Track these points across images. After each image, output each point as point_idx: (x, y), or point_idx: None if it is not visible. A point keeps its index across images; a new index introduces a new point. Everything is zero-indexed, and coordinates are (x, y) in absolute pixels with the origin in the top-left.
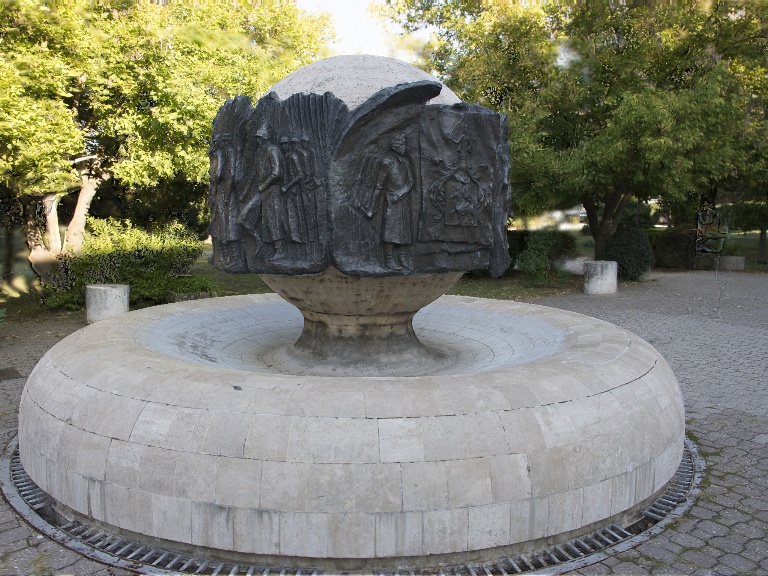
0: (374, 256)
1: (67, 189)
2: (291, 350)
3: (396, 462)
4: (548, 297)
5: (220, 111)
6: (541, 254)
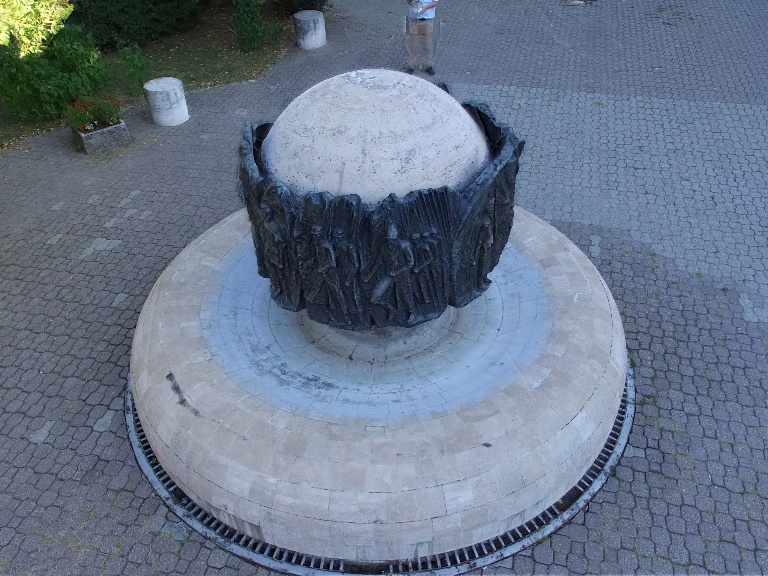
0: (473, 286)
1: None
2: (344, 332)
3: (588, 439)
4: (278, 65)
5: (307, 200)
6: (254, 17)
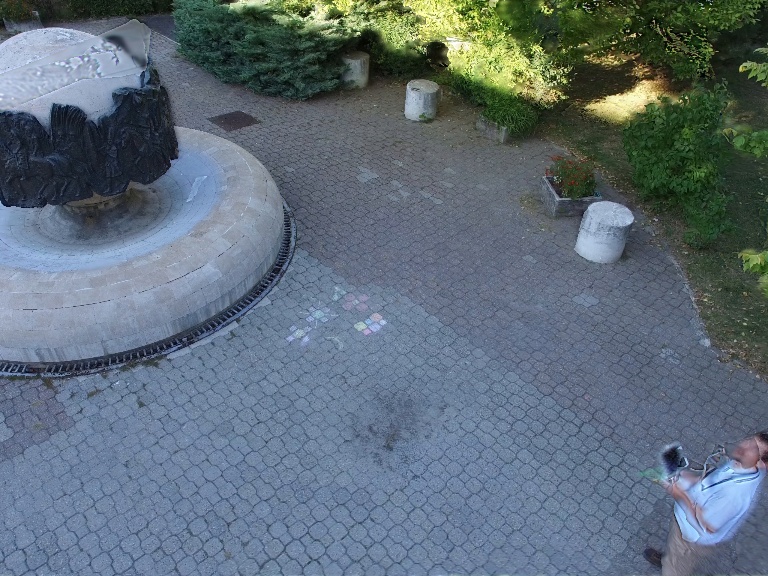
0: None
1: None
2: None
3: None
4: None
5: None
6: None
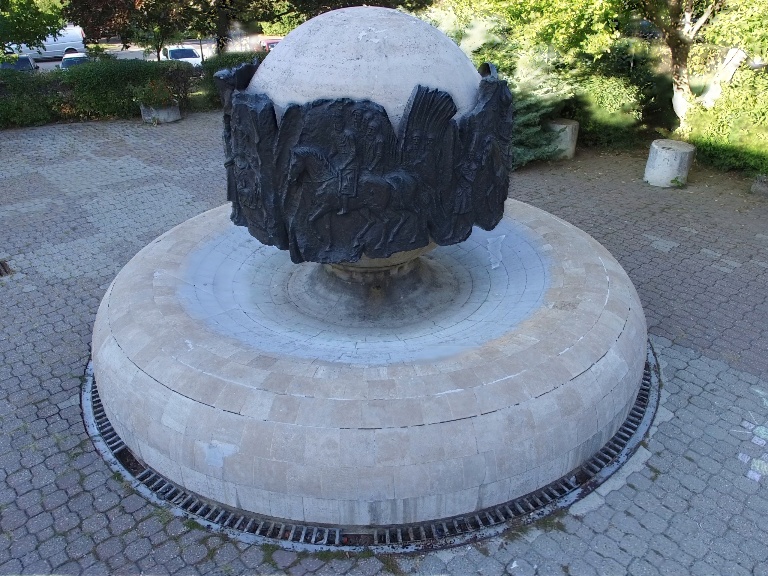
0: None
1: (600, 51)
2: None
3: None
4: None
5: None
6: None
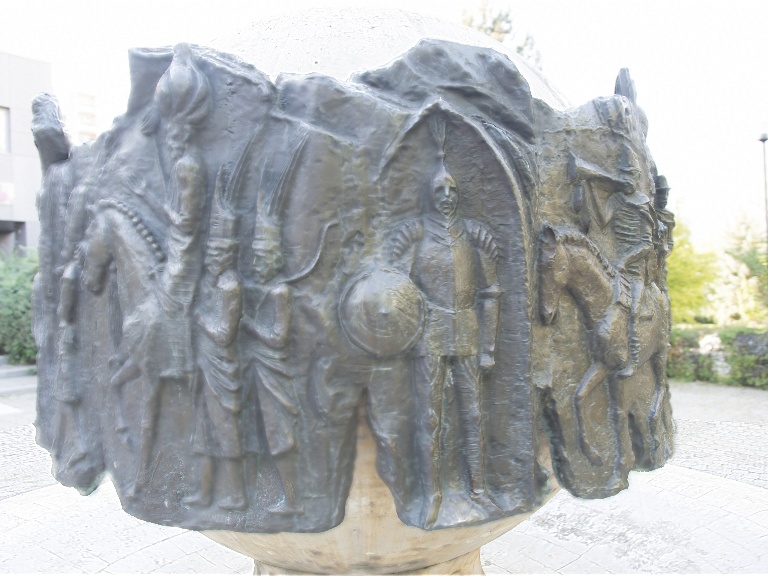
0: None
1: None
2: None
3: None
4: None
5: None
6: None
